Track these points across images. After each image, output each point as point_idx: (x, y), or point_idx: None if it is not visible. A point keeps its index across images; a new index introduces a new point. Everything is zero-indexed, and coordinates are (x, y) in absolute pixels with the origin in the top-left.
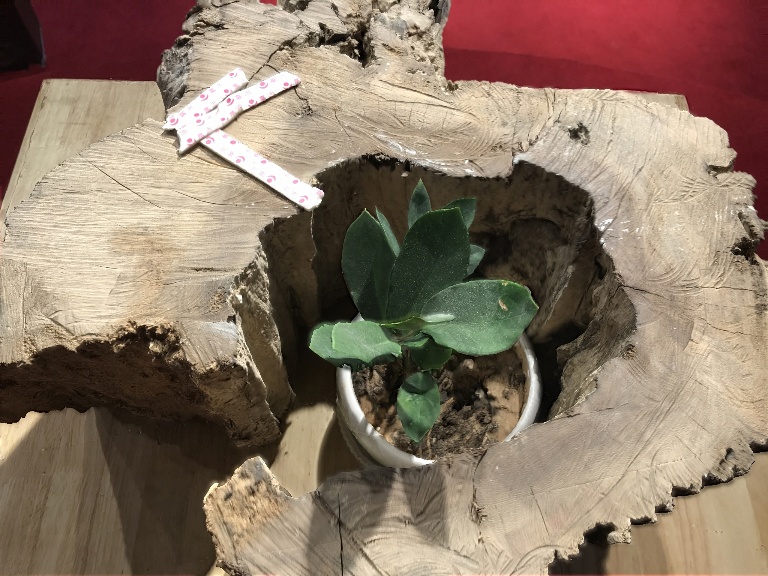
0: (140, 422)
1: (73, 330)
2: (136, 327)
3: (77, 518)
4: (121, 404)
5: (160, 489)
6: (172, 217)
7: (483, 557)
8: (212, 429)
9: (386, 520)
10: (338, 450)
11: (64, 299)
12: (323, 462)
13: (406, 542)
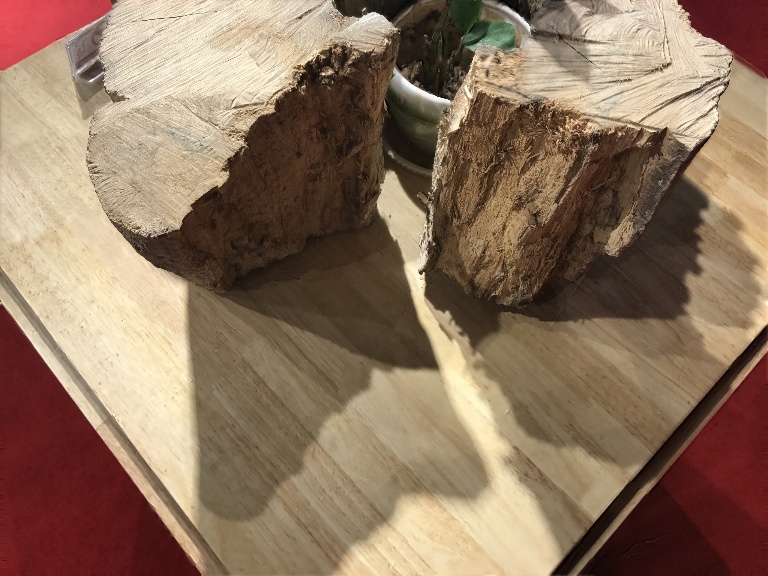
0: (269, 278)
1: (260, 100)
2: (303, 67)
3: (293, 364)
4: (267, 238)
5: (331, 301)
6: (238, 8)
7: (640, 7)
8: (325, 242)
9: (581, 19)
10: (421, 189)
11: (229, 90)
12: (419, 202)
13: (601, 23)
